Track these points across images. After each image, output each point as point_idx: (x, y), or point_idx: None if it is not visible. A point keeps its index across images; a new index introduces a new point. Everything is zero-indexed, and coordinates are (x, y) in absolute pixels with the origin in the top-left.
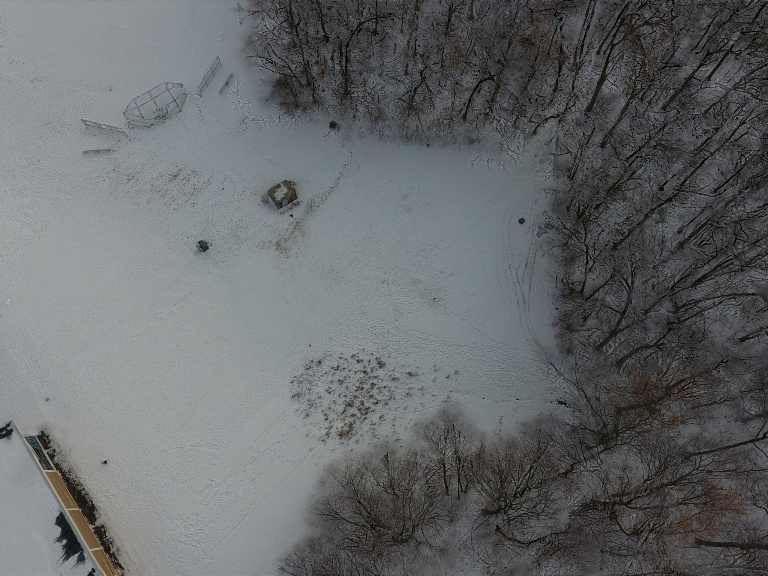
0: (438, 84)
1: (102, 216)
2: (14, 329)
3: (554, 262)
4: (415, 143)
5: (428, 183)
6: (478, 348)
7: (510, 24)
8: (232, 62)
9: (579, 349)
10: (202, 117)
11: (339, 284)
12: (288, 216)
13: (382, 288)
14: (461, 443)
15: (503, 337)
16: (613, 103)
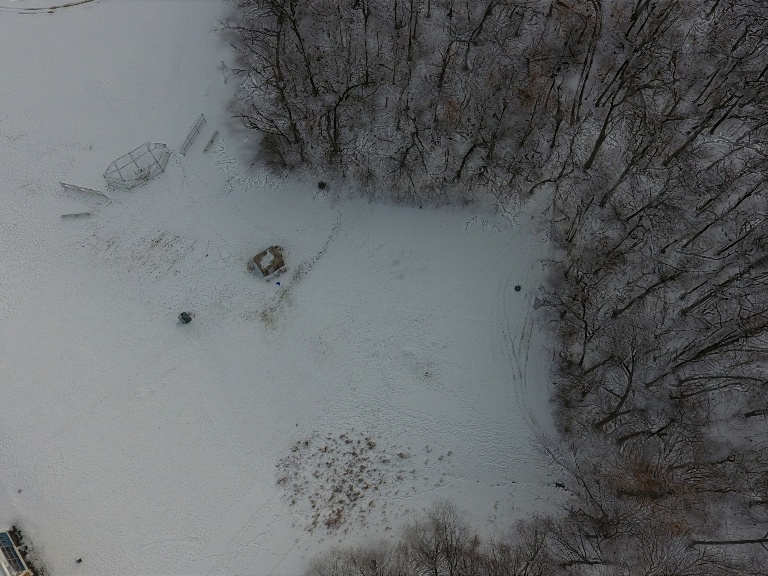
0: (431, 140)
1: (80, 286)
2: None
3: (551, 333)
4: (407, 204)
5: (420, 248)
6: (472, 427)
7: None
8: (217, 119)
9: (578, 429)
10: (186, 178)
11: (327, 358)
12: (275, 284)
13: (372, 362)
14: (453, 547)
15: (498, 415)
16: (612, 159)
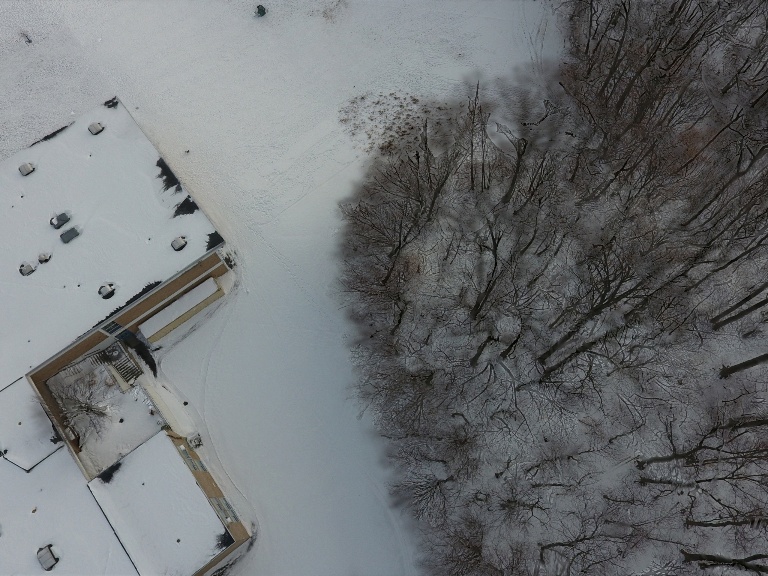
0: None
1: None
2: (106, 59)
3: (563, 29)
4: None
5: None
6: (498, 91)
7: None
8: None
9: (584, 89)
10: None
11: (378, 43)
12: None
13: (415, 46)
14: (487, 117)
15: (519, 83)
16: None
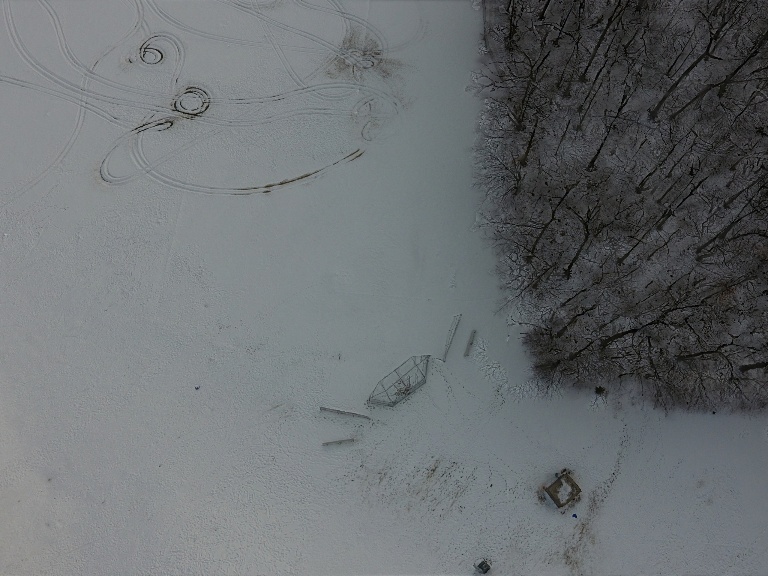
0: (703, 326)
1: (360, 532)
2: None
3: None
4: (698, 410)
5: (724, 463)
6: None
7: (767, 243)
8: (474, 317)
9: None
10: (450, 389)
11: None
12: (571, 517)
13: None
14: None
15: None
16: None
